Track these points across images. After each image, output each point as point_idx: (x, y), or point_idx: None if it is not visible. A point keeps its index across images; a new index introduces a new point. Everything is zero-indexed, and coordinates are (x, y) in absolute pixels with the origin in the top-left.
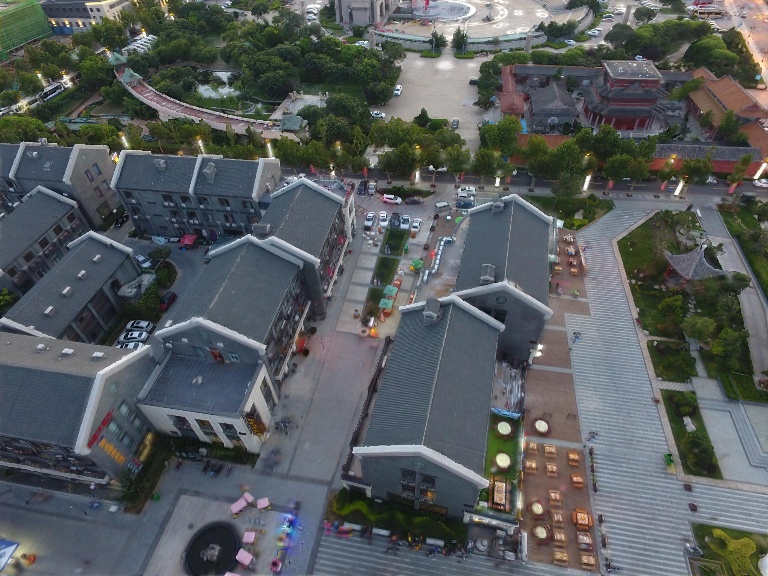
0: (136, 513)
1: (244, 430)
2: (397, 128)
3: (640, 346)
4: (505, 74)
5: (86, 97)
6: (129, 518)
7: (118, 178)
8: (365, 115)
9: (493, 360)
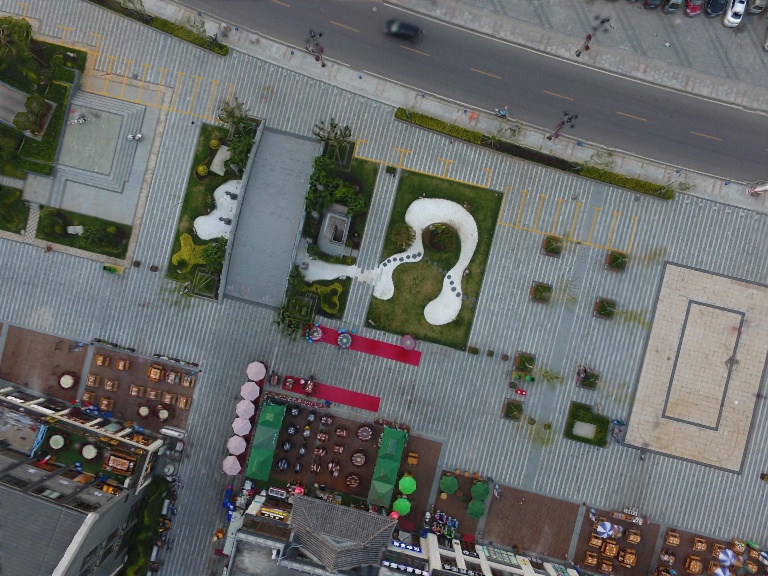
0: None
1: None
2: None
3: None
4: None
5: None
6: None
7: None
8: None
9: None
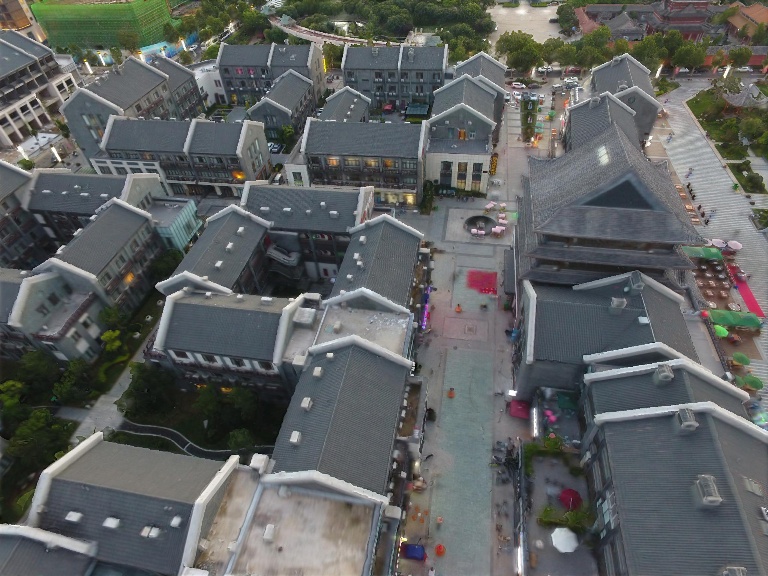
0: (427, 215)
1: (488, 168)
2: (519, 37)
3: (710, 147)
4: (579, 13)
5: (249, 39)
6: (425, 216)
7: (345, 62)
8: (479, 40)
9: (633, 124)
